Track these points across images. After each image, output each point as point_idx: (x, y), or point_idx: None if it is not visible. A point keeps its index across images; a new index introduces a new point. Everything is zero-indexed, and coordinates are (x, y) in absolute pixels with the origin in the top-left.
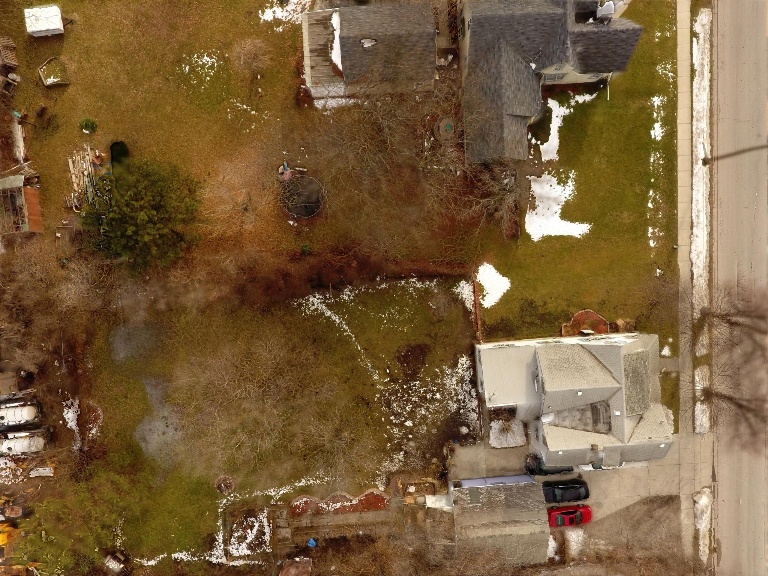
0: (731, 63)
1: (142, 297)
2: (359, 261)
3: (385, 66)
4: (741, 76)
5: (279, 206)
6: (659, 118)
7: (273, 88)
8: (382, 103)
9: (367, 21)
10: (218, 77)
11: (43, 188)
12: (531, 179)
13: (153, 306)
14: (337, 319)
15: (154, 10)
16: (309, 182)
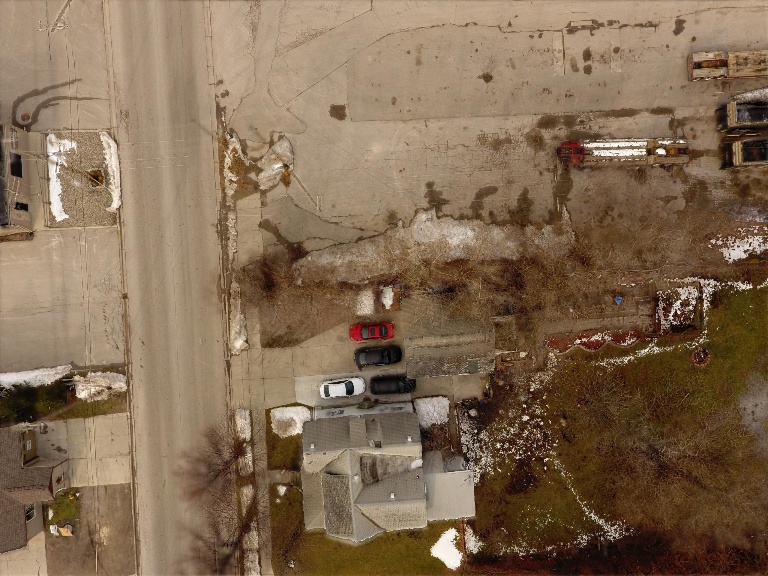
0: None
1: None
2: None
3: None
4: None
5: None
6: None
7: None
8: None
9: None
10: None
11: None
12: None
13: (763, 527)
14: (593, 517)
15: None
16: None
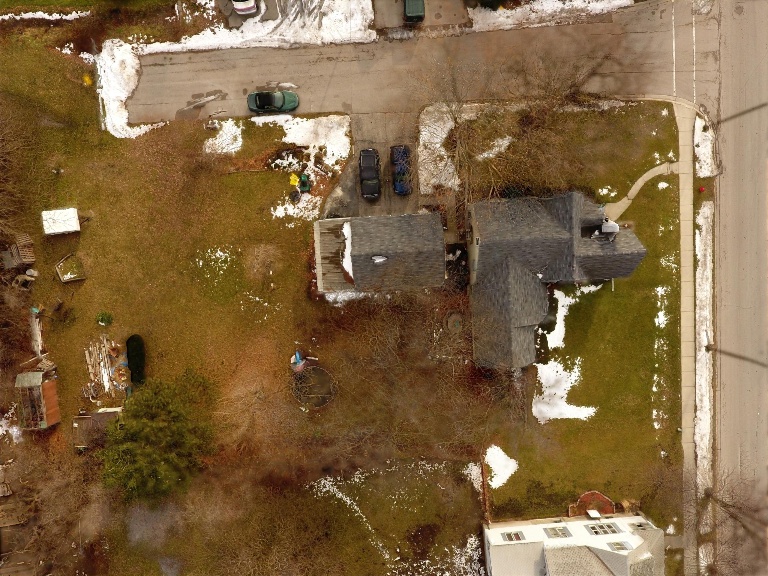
0: (733, 253)
1: (157, 481)
2: (370, 452)
3: (395, 276)
4: (743, 265)
5: (291, 394)
6: (663, 307)
7: (285, 281)
8: (392, 296)
9: (378, 235)
10: (231, 271)
11: (60, 378)
12: (538, 366)
13: (168, 489)
14: (348, 500)
15: (168, 207)
16: (321, 374)
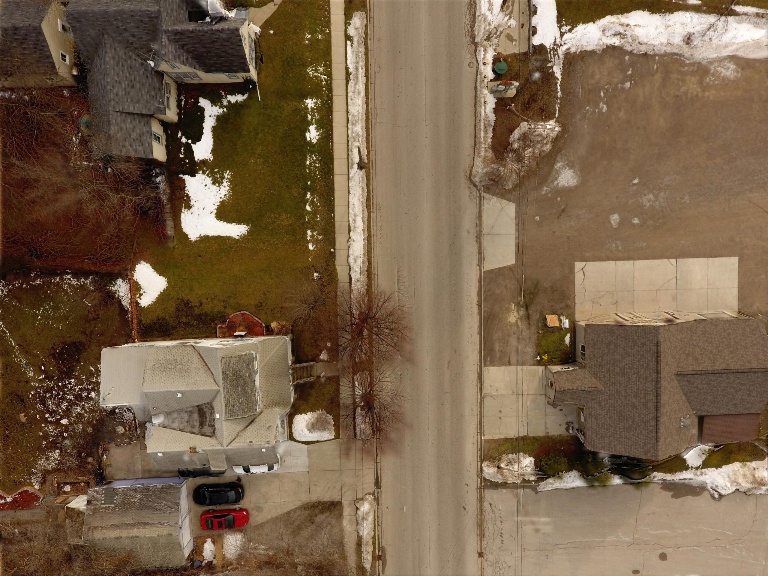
0: (388, 67)
1: None
2: None
3: (2, 59)
4: (398, 81)
5: None
6: (314, 120)
7: None
8: (30, 97)
9: None
10: None
11: None
12: (185, 178)
13: None
14: None
15: None
16: None
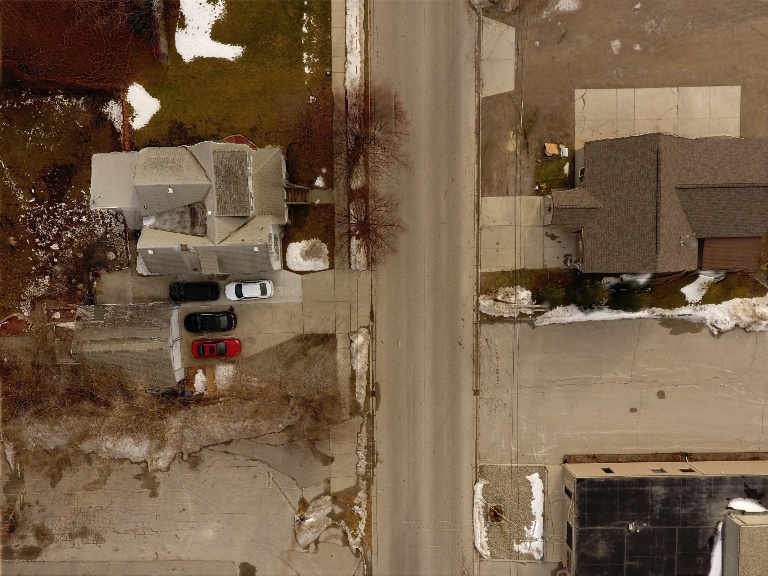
0: None
1: None
2: None
3: None
4: None
5: None
6: None
7: None
8: None
9: None
10: None
11: None
12: None
13: None
14: None
15: None
16: None
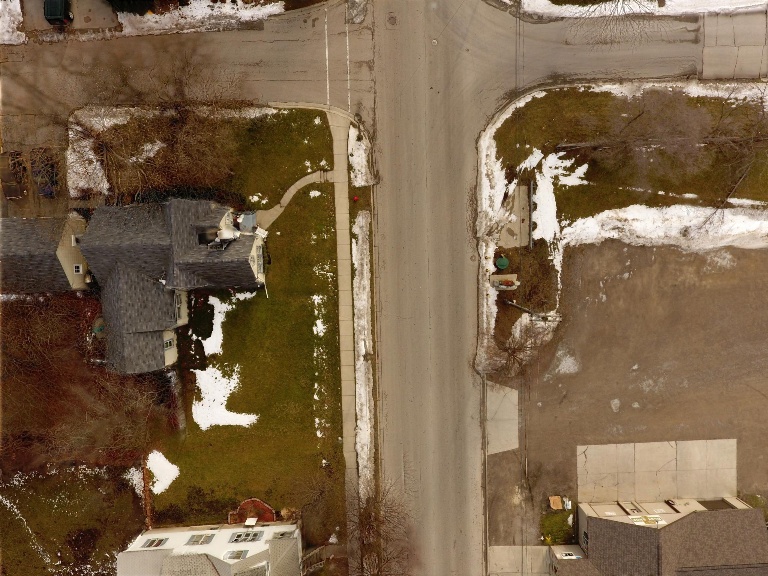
0: (392, 262)
1: None
2: (16, 455)
3: (18, 279)
4: (402, 275)
5: None
6: (320, 315)
7: None
8: (44, 299)
9: None
10: None
11: None
12: (196, 372)
13: None
14: (8, 503)
15: None
16: None
